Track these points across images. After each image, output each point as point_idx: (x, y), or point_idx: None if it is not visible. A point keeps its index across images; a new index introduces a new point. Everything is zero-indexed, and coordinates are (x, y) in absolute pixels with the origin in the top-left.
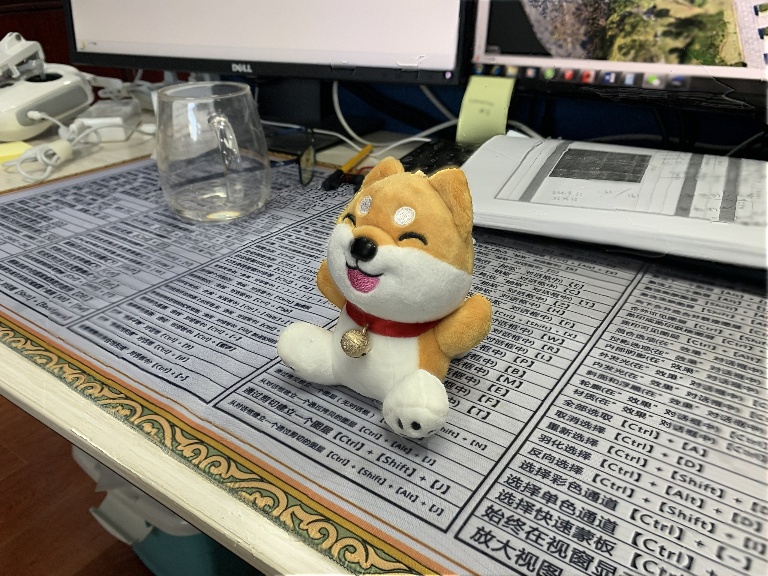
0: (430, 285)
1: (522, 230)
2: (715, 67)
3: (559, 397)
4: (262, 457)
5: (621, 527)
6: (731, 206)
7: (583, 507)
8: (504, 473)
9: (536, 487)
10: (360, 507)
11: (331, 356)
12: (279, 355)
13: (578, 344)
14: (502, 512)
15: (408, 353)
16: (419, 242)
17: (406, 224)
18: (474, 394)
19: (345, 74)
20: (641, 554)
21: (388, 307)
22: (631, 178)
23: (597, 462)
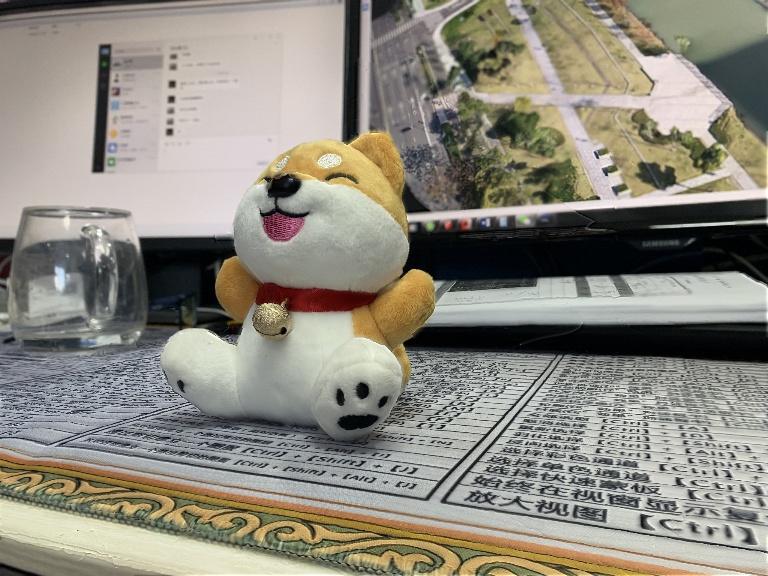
0: (365, 225)
1: (432, 324)
2: (574, 203)
3: (521, 412)
4: (133, 473)
5: (656, 475)
6: (626, 289)
7: (599, 467)
8: (484, 456)
9: (531, 461)
10: (292, 495)
11: (235, 365)
12: (164, 364)
13: (522, 387)
14: (498, 478)
15: (340, 329)
16: (349, 180)
17: (332, 167)
18: (420, 417)
19: (229, 244)
20: (696, 489)
21: (315, 257)
22: (526, 285)
23: (593, 442)
